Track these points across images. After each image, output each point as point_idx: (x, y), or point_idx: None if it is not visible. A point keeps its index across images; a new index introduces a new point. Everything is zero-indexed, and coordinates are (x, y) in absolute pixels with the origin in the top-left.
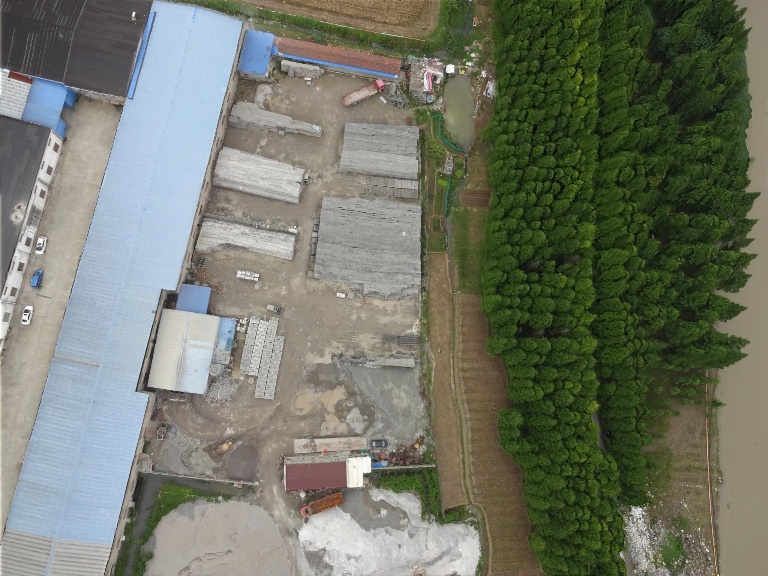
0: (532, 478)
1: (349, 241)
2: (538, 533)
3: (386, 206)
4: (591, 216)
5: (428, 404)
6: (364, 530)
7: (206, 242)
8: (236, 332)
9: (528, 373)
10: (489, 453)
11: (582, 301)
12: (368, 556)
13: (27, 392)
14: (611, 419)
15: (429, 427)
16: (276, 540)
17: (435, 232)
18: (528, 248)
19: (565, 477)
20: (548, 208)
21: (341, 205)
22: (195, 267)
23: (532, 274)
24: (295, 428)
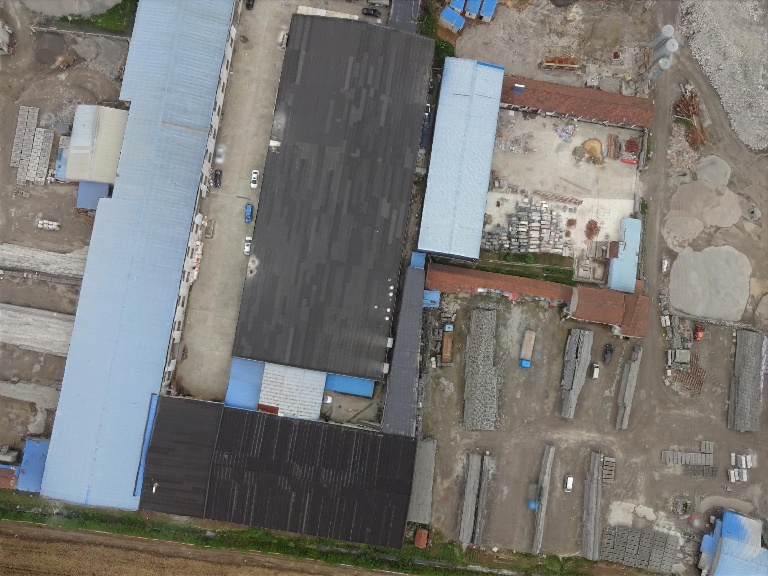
0: None
1: None
2: None
3: None
4: None
5: None
6: None
7: (85, 254)
8: None
9: None
10: None
11: None
12: None
13: (249, 110)
14: None
15: None
16: None
17: None
18: None
19: None
20: None
21: None
22: None
23: None
24: (0, 80)
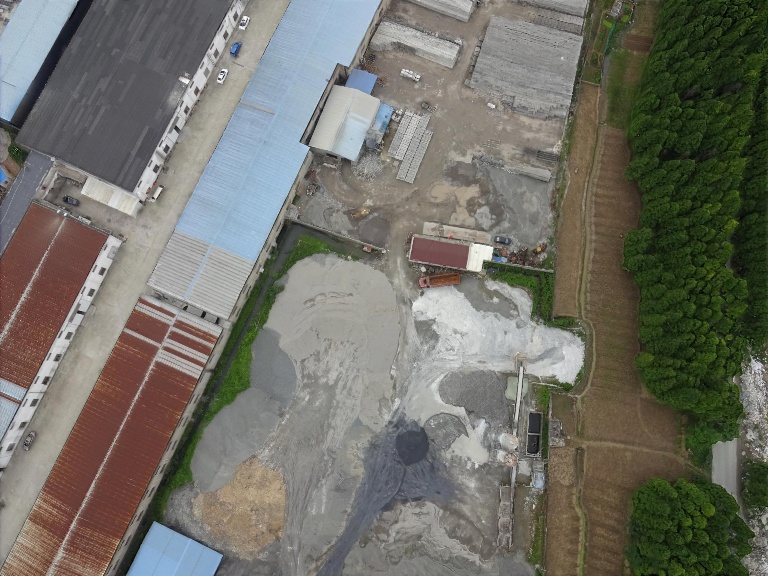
0: (651, 294)
1: (509, 56)
2: (647, 350)
3: (549, 31)
4: (761, 46)
5: (557, 215)
6: (475, 310)
7: (381, 38)
8: (391, 120)
9: (666, 189)
10: (608, 276)
11: (737, 124)
12: (474, 335)
13: (209, 137)
14: (747, 251)
15: (554, 236)
16: (392, 304)
17: (592, 66)
18: (687, 72)
19: (688, 291)
20: (715, 40)
21: (507, 24)
22: (366, 61)
23: (687, 101)
24: (427, 212)
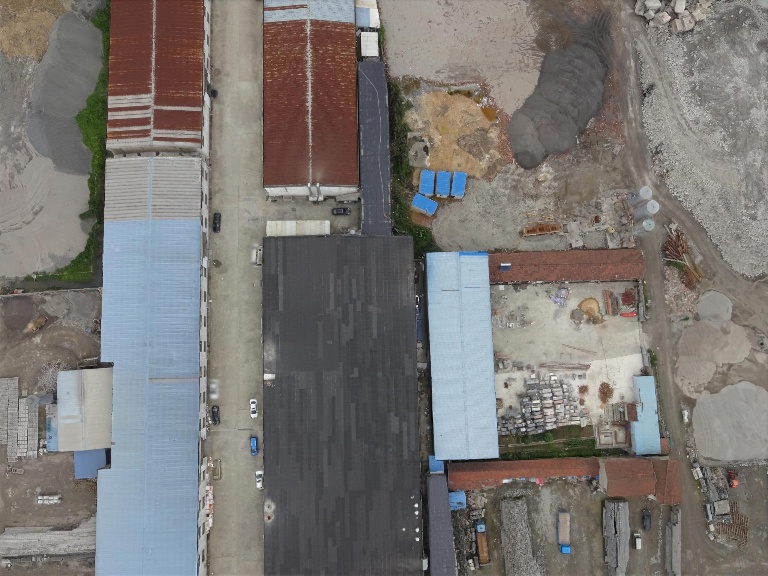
0: None
1: None
2: None
3: None
4: None
5: None
6: None
7: (92, 526)
8: None
9: None
10: None
11: None
12: None
13: (236, 337)
14: None
15: None
16: None
17: None
18: None
19: None
20: None
21: None
22: None
23: None
24: None
